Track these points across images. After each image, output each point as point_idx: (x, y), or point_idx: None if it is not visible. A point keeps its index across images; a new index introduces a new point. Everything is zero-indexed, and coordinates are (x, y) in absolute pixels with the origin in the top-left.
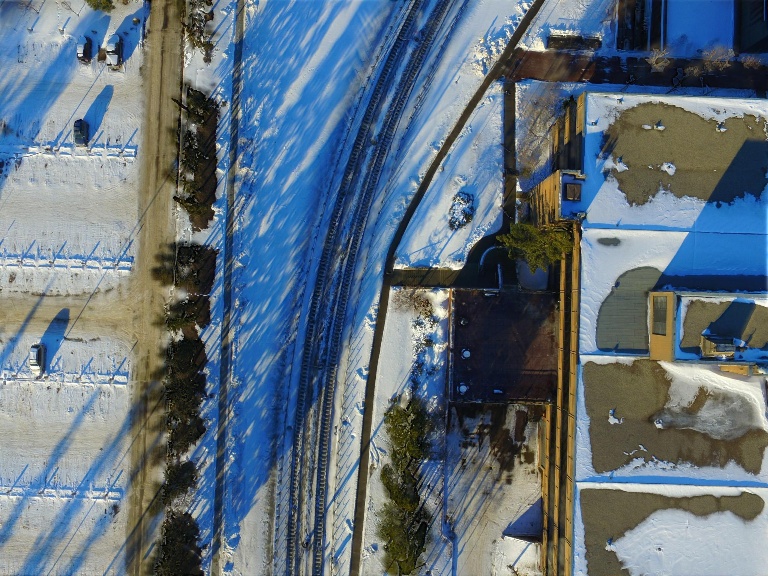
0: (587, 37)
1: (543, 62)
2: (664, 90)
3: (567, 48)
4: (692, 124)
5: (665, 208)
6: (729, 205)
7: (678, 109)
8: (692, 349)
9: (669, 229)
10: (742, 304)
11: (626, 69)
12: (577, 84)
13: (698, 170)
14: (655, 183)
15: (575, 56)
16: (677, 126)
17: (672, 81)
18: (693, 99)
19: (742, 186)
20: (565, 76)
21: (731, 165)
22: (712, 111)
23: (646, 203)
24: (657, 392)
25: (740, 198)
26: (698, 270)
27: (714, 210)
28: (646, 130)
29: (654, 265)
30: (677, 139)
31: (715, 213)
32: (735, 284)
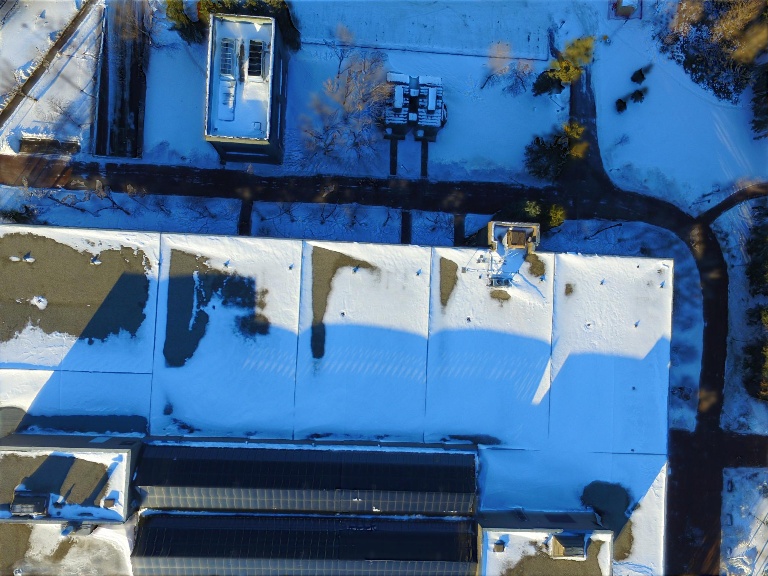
0: (64, 141)
1: (14, 166)
2: (142, 199)
3: (41, 152)
4: (64, 256)
5: (32, 345)
6: (102, 342)
7: (49, 240)
8: (4, 506)
9: (33, 367)
10: (61, 458)
11: (105, 175)
12: (50, 190)
13: (71, 304)
14: (23, 318)
15: (50, 161)
16: (48, 258)
17: (154, 189)
18: (64, 230)
19: (117, 322)
20: (38, 182)
21: (106, 299)
22: (86, 243)
23: (11, 339)
24: (17, 540)
25: (115, 334)
26: (65, 411)
27: (85, 347)
28: (14, 262)
29: (17, 405)
30: (48, 272)
31: (86, 350)
32: (104, 425)
